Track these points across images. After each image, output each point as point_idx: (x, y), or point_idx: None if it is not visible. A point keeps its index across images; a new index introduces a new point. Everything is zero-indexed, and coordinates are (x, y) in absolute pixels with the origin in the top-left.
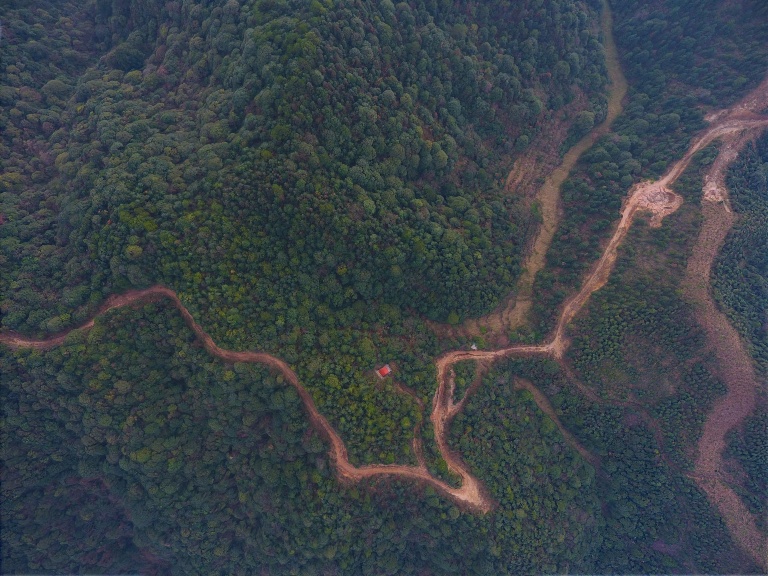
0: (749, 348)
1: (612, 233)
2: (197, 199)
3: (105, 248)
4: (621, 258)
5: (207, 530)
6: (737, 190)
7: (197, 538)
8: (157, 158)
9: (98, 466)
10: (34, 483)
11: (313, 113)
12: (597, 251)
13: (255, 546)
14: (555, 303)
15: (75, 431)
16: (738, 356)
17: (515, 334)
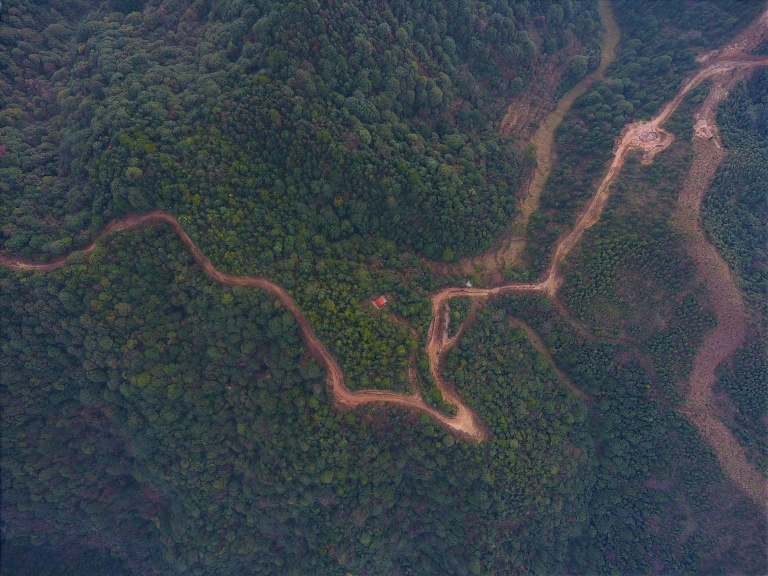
0: (739, 281)
1: (605, 172)
2: (196, 125)
3: (106, 171)
4: (613, 195)
5: (206, 462)
6: (727, 128)
7: (196, 469)
8: (157, 87)
9: (99, 394)
10: (36, 411)
11: (310, 41)
12: (590, 190)
13: (253, 477)
14: (549, 241)
15: (77, 355)
16: (728, 287)
17: (509, 272)
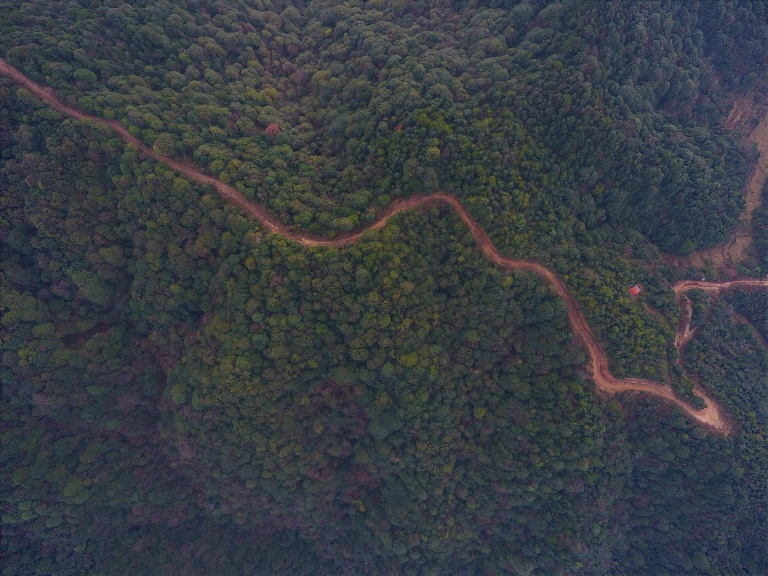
0: None
1: None
2: (486, 107)
3: (399, 151)
4: None
5: (442, 445)
6: None
7: (432, 452)
8: (439, 70)
9: (355, 372)
10: (292, 387)
11: (600, 28)
12: None
13: (490, 462)
14: None
15: (348, 333)
16: None
17: (742, 267)
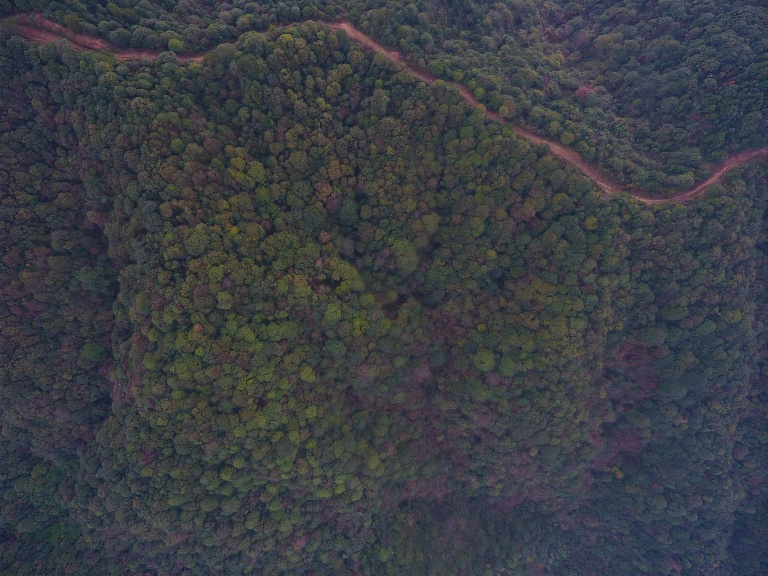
0: None
1: None
2: None
3: (738, 106)
4: None
5: (733, 404)
6: None
7: (724, 412)
8: None
9: None
10: None
11: None
12: None
13: None
14: None
15: (674, 291)
16: None
17: None
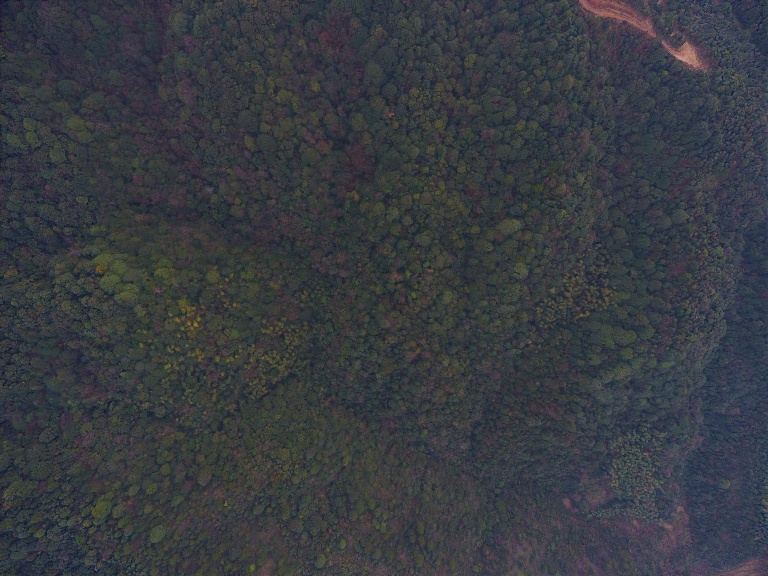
0: None
1: None
2: None
3: None
4: None
5: (434, 94)
6: None
7: (424, 101)
8: None
9: None
10: (290, 14)
11: None
12: None
13: (479, 109)
14: None
15: None
16: None
17: None
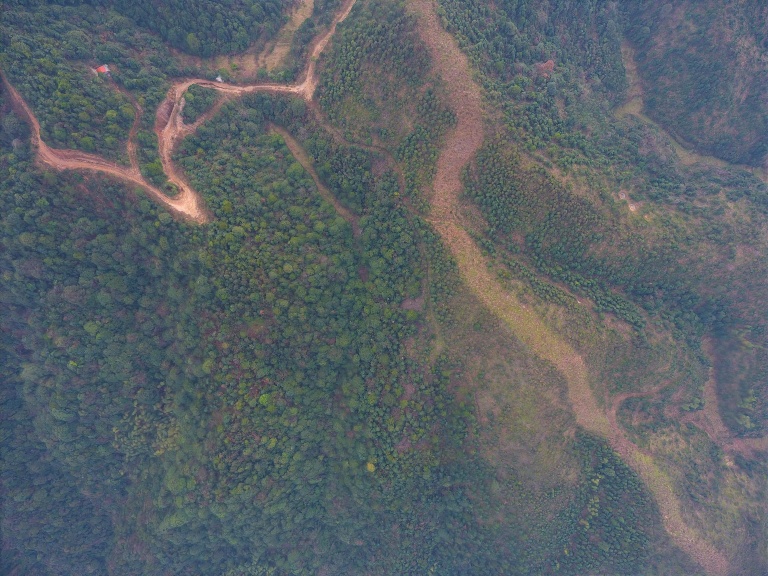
0: (481, 78)
1: None
2: None
3: None
4: None
5: None
6: None
7: None
8: None
9: None
10: None
11: None
12: None
13: None
14: (305, 40)
15: None
16: (462, 78)
17: None
